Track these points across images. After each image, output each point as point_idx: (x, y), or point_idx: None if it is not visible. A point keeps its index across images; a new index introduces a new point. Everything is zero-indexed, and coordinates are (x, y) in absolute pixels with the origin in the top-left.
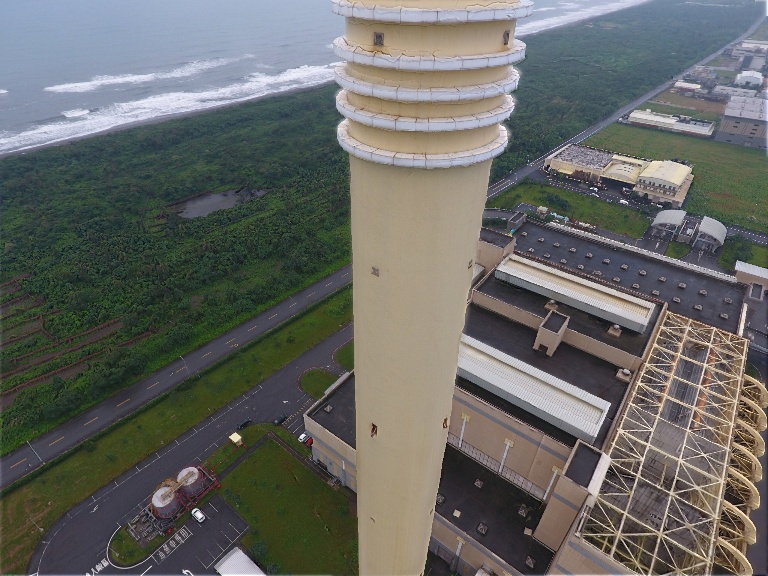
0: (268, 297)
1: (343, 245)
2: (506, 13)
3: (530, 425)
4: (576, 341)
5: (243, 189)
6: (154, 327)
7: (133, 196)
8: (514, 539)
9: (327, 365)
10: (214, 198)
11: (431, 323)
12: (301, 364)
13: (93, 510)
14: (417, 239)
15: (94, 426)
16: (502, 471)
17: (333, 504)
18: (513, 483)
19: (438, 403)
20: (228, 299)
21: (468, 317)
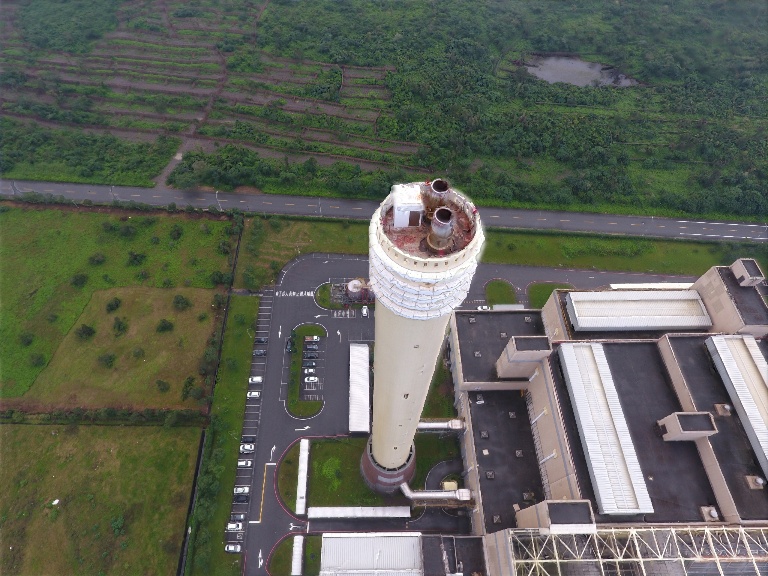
0: (528, 199)
1: (642, 193)
2: (412, 279)
3: (573, 459)
4: (705, 453)
5: (611, 69)
6: (434, 168)
7: (510, 29)
8: (503, 500)
9: (519, 287)
10: (577, 65)
11: (390, 353)
12: (501, 271)
13: (324, 262)
14: (383, 319)
15: (356, 213)
16: (542, 464)
17: (434, 374)
18: (542, 477)
19: (398, 385)
20: (498, 179)
21: (636, 351)
